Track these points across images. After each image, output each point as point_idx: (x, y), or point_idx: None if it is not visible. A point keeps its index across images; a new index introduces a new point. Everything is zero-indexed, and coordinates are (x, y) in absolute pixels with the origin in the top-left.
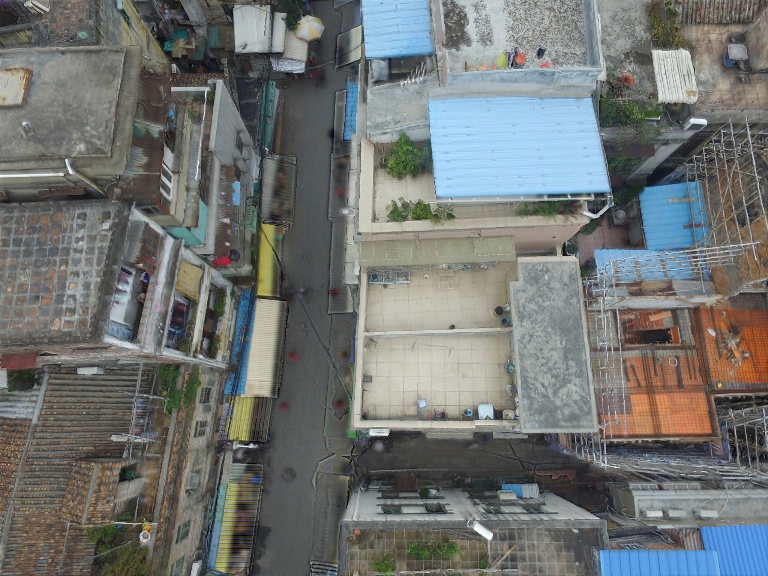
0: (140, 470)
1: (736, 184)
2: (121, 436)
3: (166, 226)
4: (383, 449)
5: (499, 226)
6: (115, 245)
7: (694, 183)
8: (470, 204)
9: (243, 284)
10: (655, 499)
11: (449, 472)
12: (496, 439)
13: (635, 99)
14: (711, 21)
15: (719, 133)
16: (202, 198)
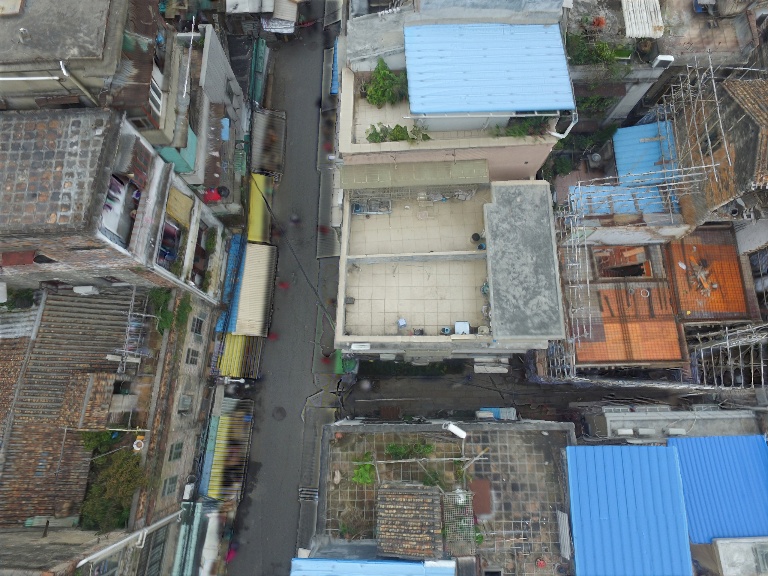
0: (134, 389)
1: (701, 117)
2: (116, 355)
3: (156, 145)
4: (370, 390)
5: (472, 146)
6: (107, 149)
7: (664, 122)
8: (445, 129)
9: (234, 227)
10: (626, 420)
11: (434, 411)
12: (479, 380)
13: (607, 41)
14: None
15: (685, 68)
16: (191, 127)
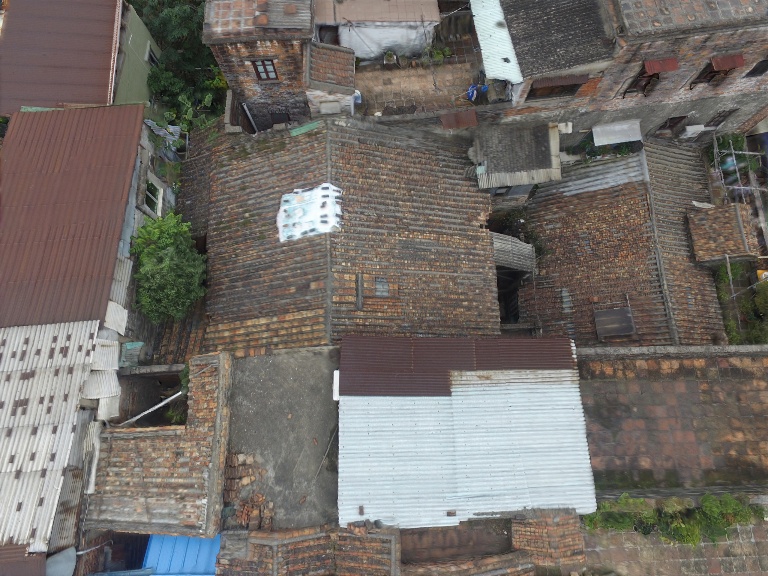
0: None
1: None
2: None
3: None
4: None
5: None
6: None
7: None
8: None
9: None
10: None
11: None
12: None
13: None
14: None
15: None
16: None
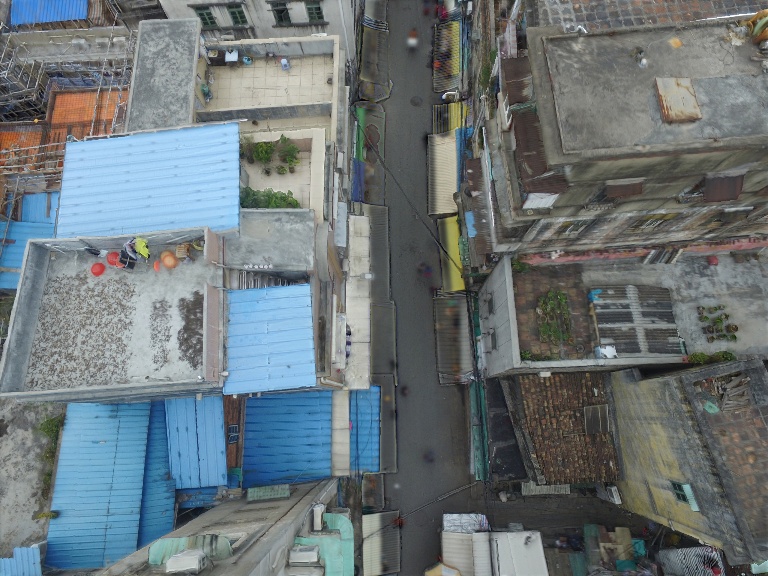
0: None
1: None
2: None
3: None
4: None
5: None
6: None
7: None
8: None
9: None
10: (117, 52)
11: None
12: None
13: None
14: None
15: None
16: None
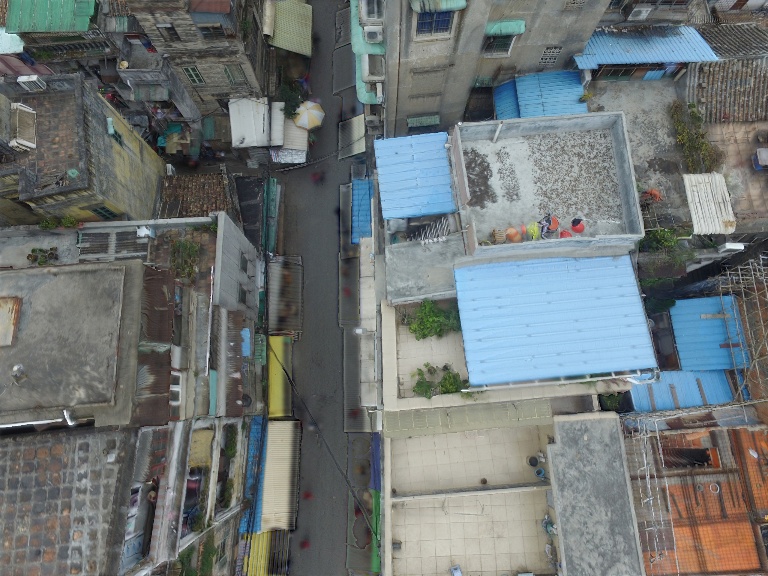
0: None
1: None
2: None
3: None
4: None
5: (535, 397)
6: (122, 482)
7: (728, 297)
8: None
9: None
10: None
11: None
12: None
13: (663, 213)
14: (736, 119)
15: (757, 258)
16: (211, 365)
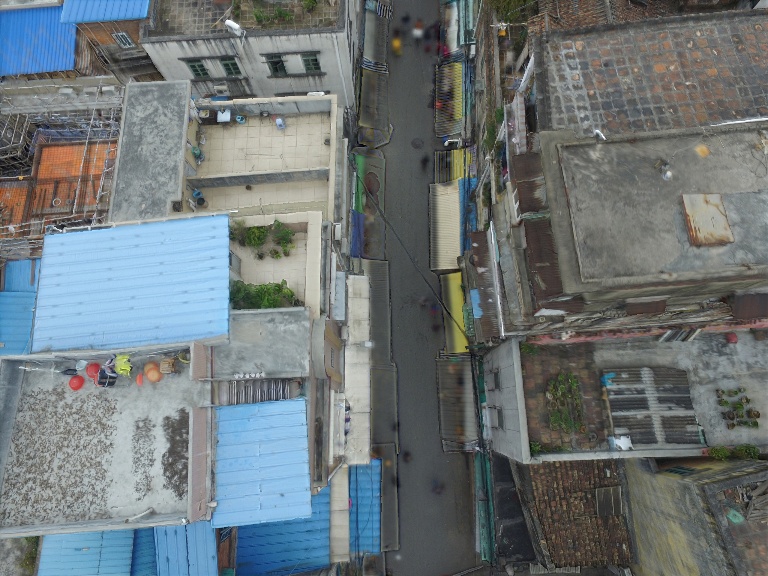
0: None
1: None
2: None
3: None
4: None
5: None
6: None
7: None
8: None
9: None
10: (106, 102)
11: None
12: None
13: None
14: None
15: None
16: None
